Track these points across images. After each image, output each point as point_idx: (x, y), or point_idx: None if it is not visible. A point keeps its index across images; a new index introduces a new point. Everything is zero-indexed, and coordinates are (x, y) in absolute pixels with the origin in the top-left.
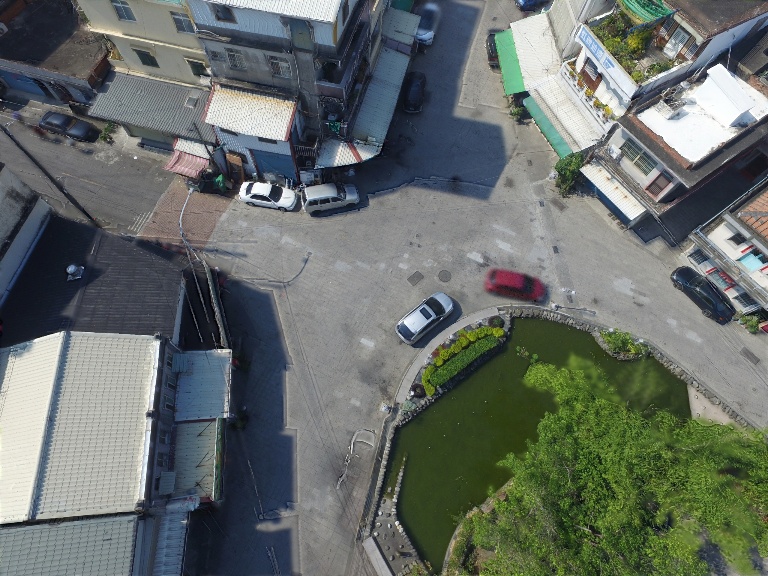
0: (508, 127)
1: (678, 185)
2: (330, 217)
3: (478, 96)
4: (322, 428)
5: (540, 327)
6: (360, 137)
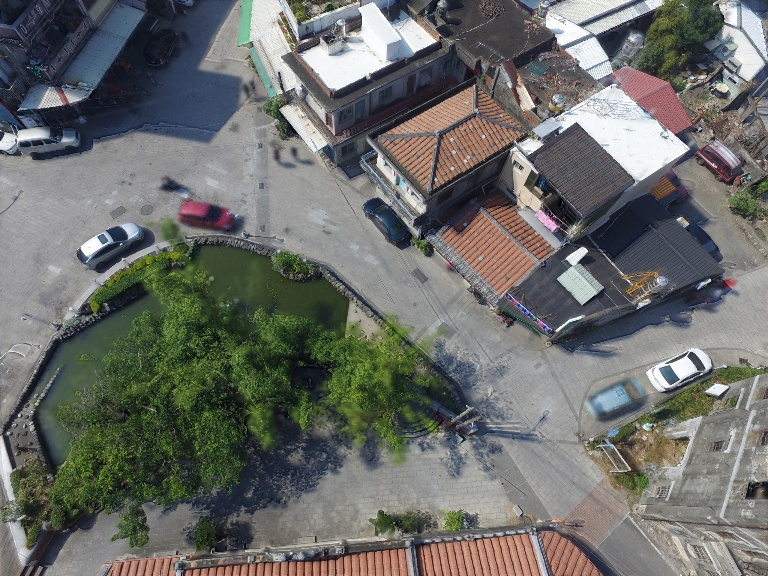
0: (248, 78)
1: (353, 119)
2: (51, 160)
3: (226, 51)
4: None
5: (225, 253)
6: (70, 82)
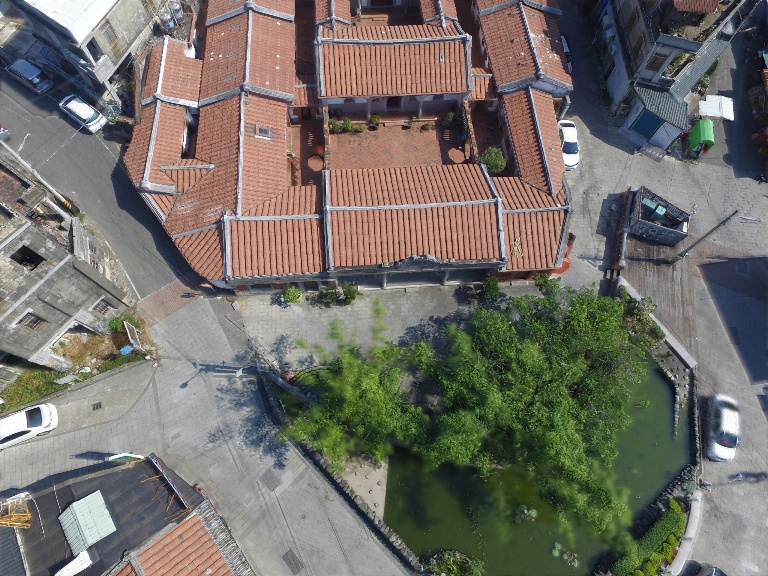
0: None
1: None
2: None
3: None
4: (761, 462)
5: None
6: None
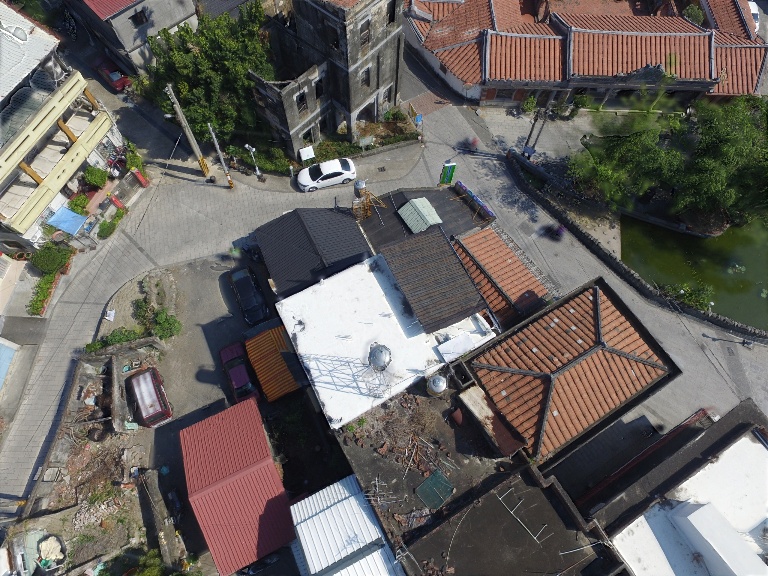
0: None
1: None
2: None
3: None
4: None
5: (761, 323)
6: None
